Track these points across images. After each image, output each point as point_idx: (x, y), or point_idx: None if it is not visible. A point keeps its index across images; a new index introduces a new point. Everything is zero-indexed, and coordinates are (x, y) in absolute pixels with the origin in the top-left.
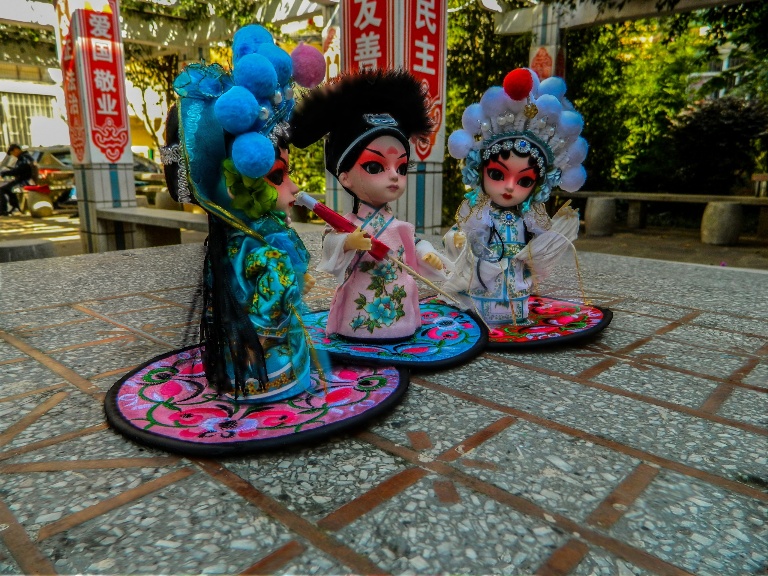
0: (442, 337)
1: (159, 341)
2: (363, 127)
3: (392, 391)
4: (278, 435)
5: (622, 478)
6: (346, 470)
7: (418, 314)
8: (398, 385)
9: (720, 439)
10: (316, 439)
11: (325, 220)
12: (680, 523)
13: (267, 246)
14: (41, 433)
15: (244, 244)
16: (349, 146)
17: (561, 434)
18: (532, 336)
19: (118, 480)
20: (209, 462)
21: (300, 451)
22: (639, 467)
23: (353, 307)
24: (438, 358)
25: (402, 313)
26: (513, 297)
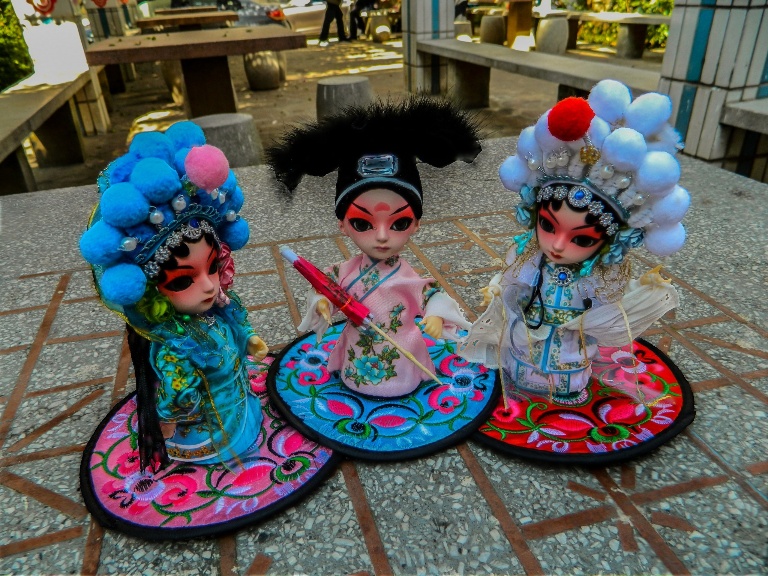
0: (436, 406)
1: None
2: (353, 177)
3: (286, 494)
4: (146, 524)
5: None
6: None
7: None
8: (302, 485)
9: None
10: None
11: None
12: None
13: (166, 350)
14: (49, 441)
15: (152, 343)
16: (339, 196)
17: None
18: (537, 437)
19: (37, 522)
20: (98, 527)
21: (163, 541)
22: None
23: (347, 356)
24: (388, 448)
25: (393, 373)
26: (555, 369)
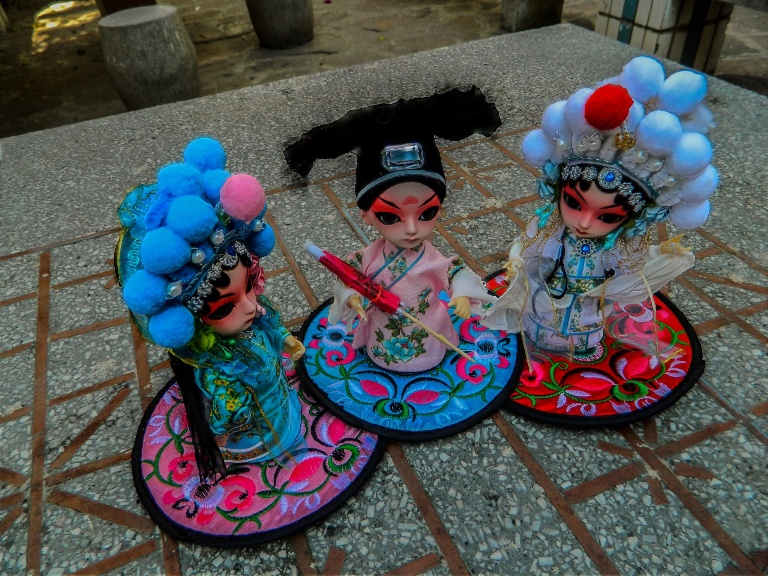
0: (465, 376)
1: None
2: (378, 170)
3: (345, 487)
4: (219, 533)
5: None
6: None
7: (452, 340)
8: (357, 476)
9: None
10: None
11: None
12: None
13: (216, 375)
14: (91, 452)
15: None
16: (363, 189)
17: None
18: (565, 400)
19: (108, 541)
20: (170, 539)
21: None
22: None
23: (374, 336)
24: (430, 427)
25: (423, 350)
26: (575, 331)
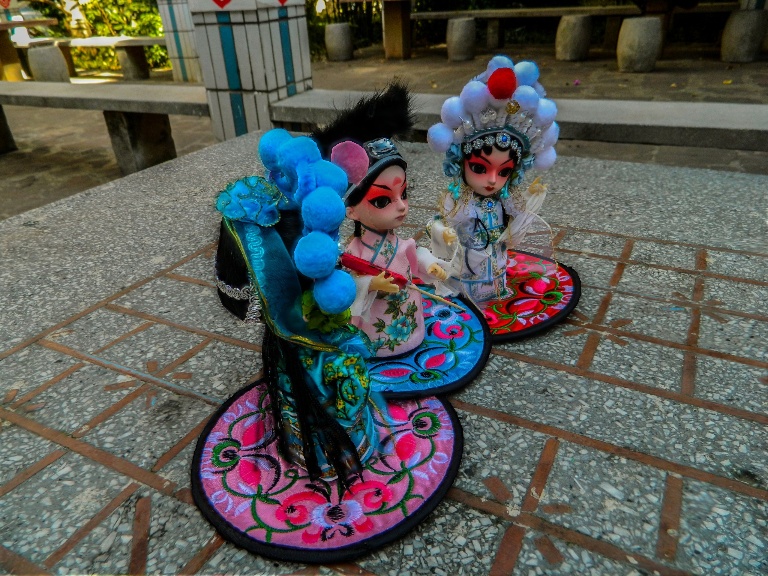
0: (449, 336)
1: (181, 391)
2: None
3: (453, 436)
4: (393, 524)
5: (661, 497)
6: (461, 544)
7: (422, 315)
8: (452, 425)
9: (708, 429)
10: None
11: (345, 266)
12: (716, 539)
13: (344, 356)
14: (167, 567)
15: (321, 358)
16: None
17: (599, 453)
18: (524, 319)
19: None
20: (346, 566)
21: None
22: (668, 481)
23: (372, 330)
24: (463, 373)
25: (415, 325)
26: None
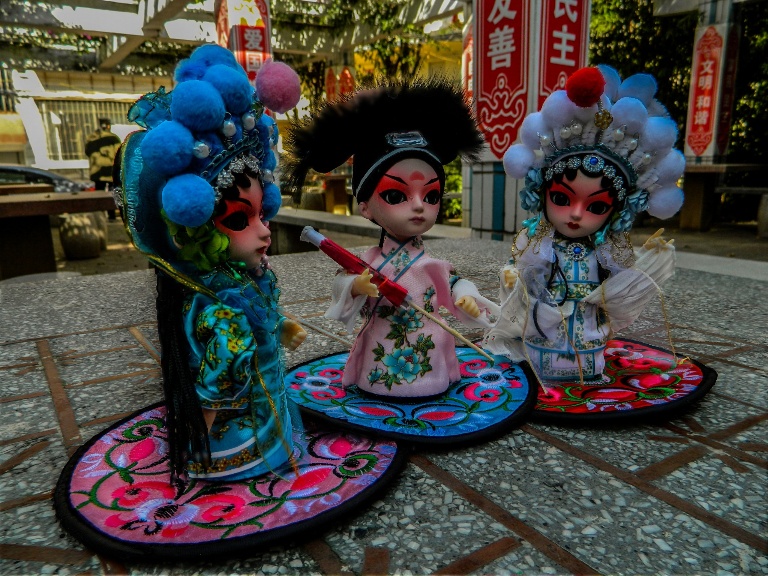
0: (478, 398)
1: None
2: (383, 149)
3: (370, 483)
4: (200, 540)
5: None
6: None
7: (455, 366)
8: (383, 473)
9: None
10: (243, 551)
11: None
12: None
13: (218, 304)
14: None
15: (194, 301)
16: (367, 172)
17: None
18: (594, 405)
19: None
20: (116, 566)
21: (226, 562)
22: None
23: (371, 358)
24: (456, 432)
25: (429, 367)
26: (581, 349)
